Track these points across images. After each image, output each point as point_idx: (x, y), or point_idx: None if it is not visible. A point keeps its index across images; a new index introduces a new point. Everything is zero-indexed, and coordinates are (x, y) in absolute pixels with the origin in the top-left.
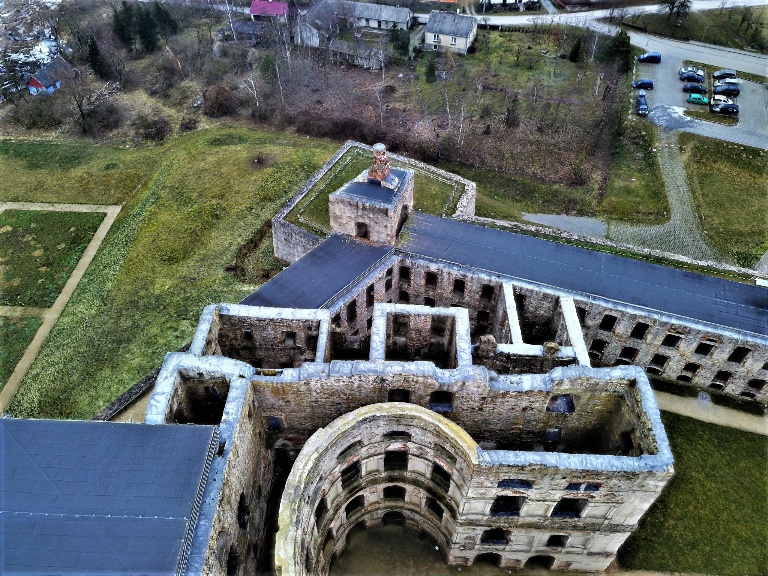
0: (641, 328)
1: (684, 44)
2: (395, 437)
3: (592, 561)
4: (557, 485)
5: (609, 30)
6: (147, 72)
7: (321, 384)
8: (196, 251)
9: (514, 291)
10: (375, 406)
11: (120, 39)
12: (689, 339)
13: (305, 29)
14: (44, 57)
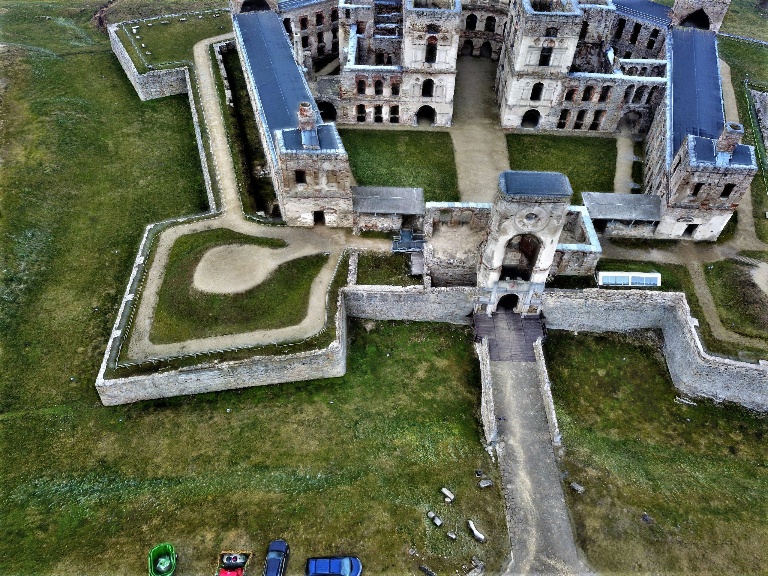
0: None
1: None
2: None
3: None
4: None
5: None
6: None
7: None
8: None
9: None
10: None
11: None
12: None
13: None
14: None
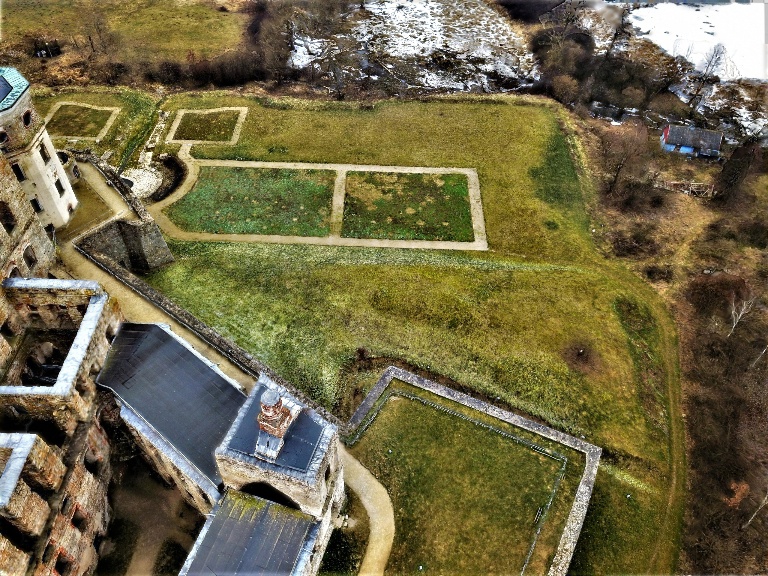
0: None
1: None
2: None
3: None
4: None
5: None
6: None
7: None
8: (391, 318)
9: None
10: None
11: None
12: None
13: None
14: (756, 130)
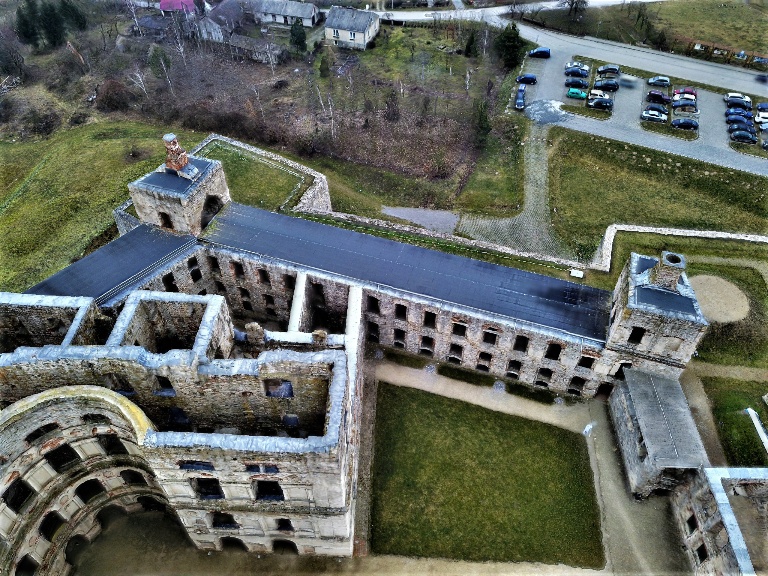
0: (431, 317)
1: (578, 39)
2: (98, 420)
3: (332, 545)
4: (235, 467)
5: (501, 25)
6: (51, 67)
7: (34, 368)
8: (47, 243)
9: (310, 281)
10: (62, 389)
11: (24, 34)
12: (472, 328)
13: (204, 24)
14: None
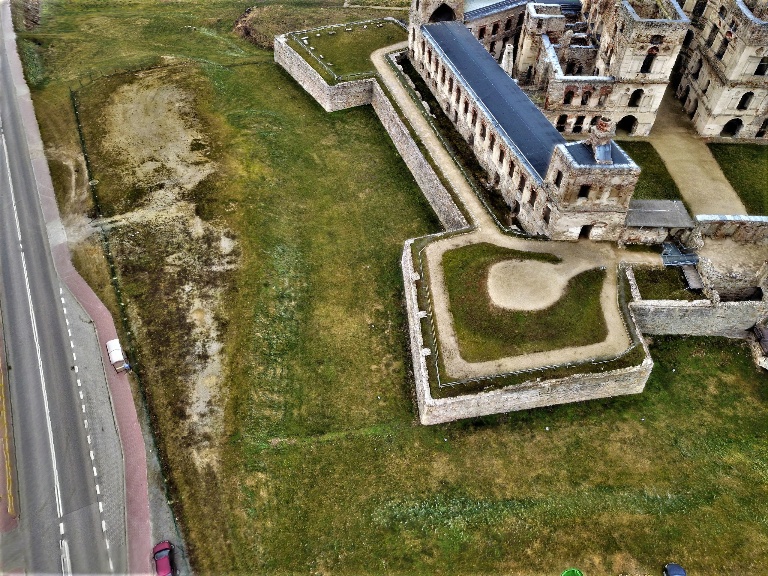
0: None
1: None
2: None
3: None
4: None
5: None
6: None
7: None
8: None
9: None
10: None
11: None
12: None
13: None
14: None
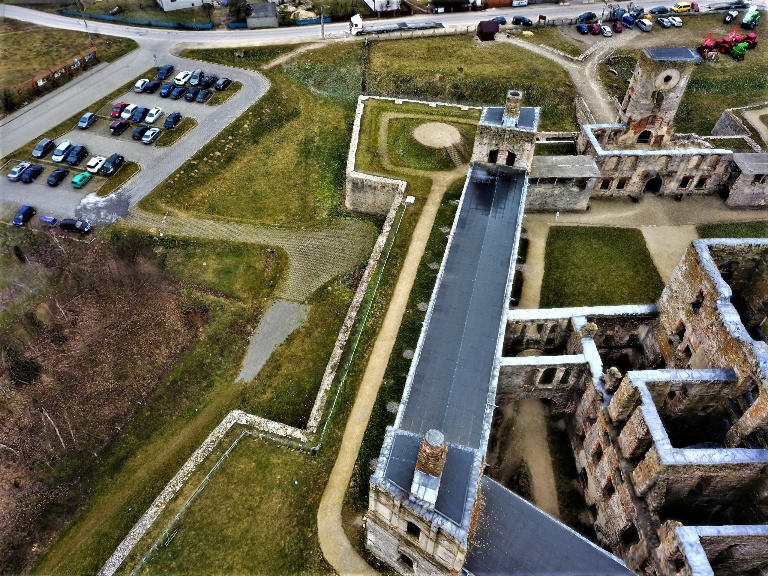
0: None
1: None
2: None
3: None
4: None
5: None
6: None
7: None
8: None
9: None
10: None
11: None
12: None
13: None
14: None
